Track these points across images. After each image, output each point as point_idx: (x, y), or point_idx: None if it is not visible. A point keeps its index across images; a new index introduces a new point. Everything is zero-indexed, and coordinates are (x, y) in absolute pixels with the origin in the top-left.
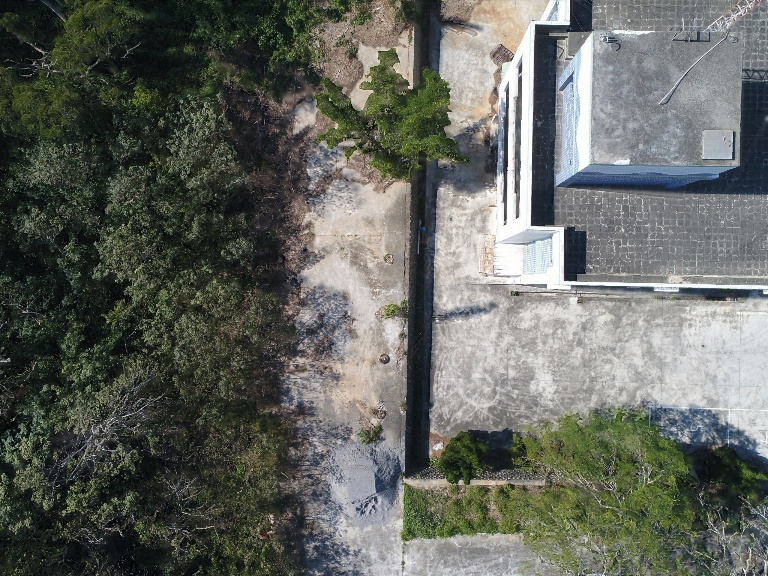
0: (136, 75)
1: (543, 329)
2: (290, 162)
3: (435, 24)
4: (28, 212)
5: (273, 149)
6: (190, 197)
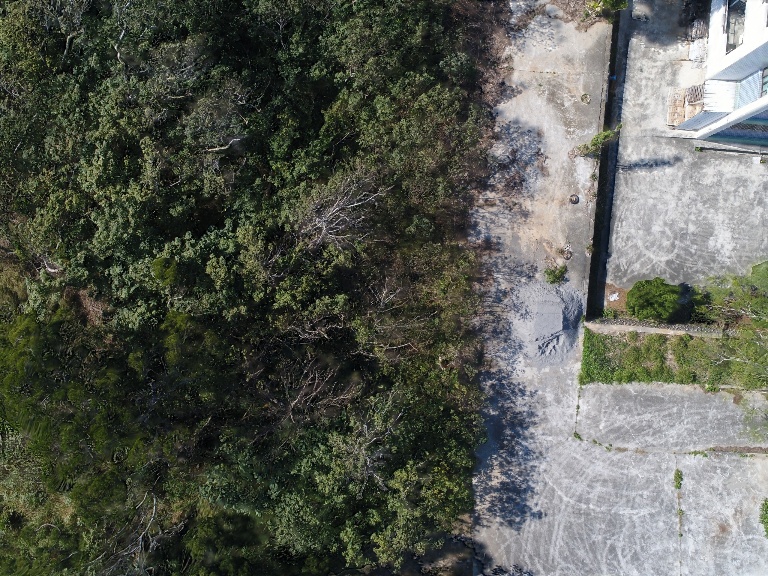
0: None
1: (725, 186)
2: None
3: None
4: None
5: None
6: (417, 1)
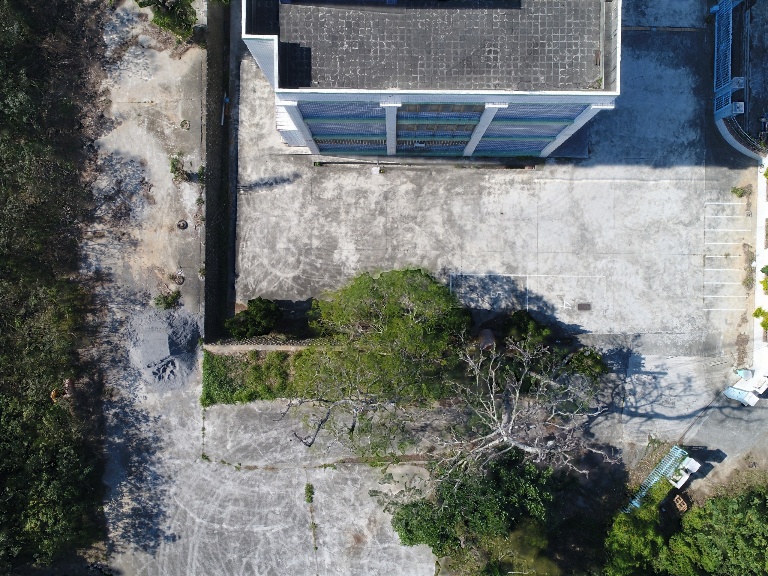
0: None
1: (346, 199)
2: (86, 29)
3: None
4: None
5: (69, 16)
6: None
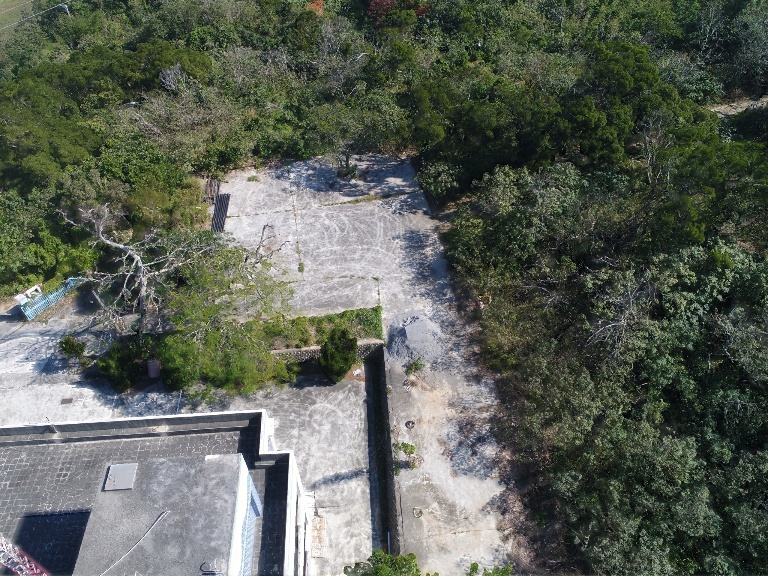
0: None
1: None
2: None
3: None
4: None
5: None
6: None
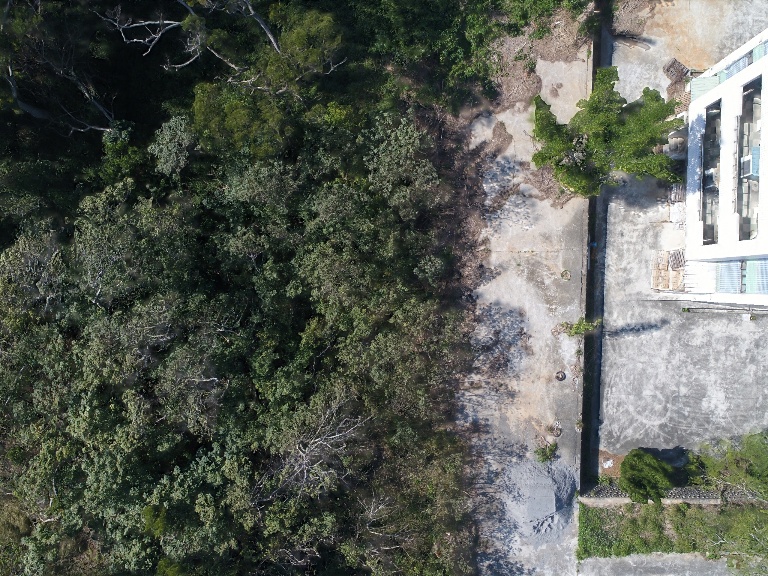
0: (316, 90)
1: (715, 346)
2: (467, 177)
3: (607, 38)
4: (231, 230)
5: (450, 164)
6: (386, 214)
